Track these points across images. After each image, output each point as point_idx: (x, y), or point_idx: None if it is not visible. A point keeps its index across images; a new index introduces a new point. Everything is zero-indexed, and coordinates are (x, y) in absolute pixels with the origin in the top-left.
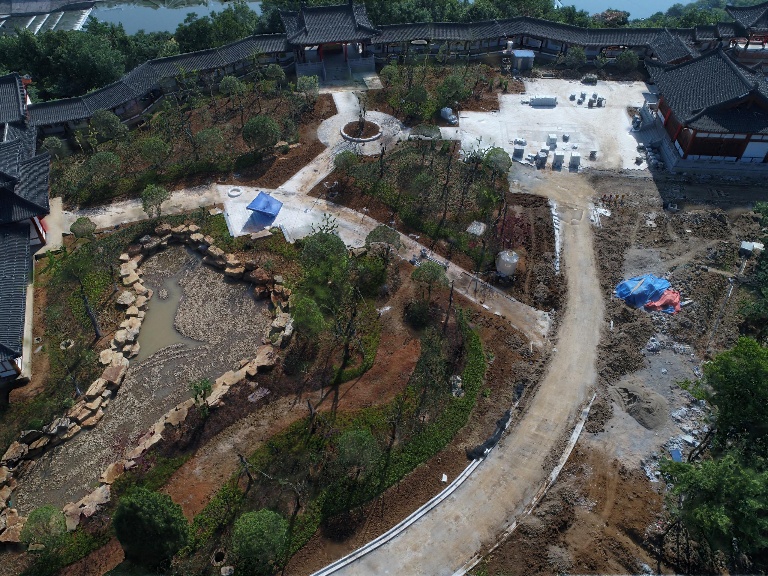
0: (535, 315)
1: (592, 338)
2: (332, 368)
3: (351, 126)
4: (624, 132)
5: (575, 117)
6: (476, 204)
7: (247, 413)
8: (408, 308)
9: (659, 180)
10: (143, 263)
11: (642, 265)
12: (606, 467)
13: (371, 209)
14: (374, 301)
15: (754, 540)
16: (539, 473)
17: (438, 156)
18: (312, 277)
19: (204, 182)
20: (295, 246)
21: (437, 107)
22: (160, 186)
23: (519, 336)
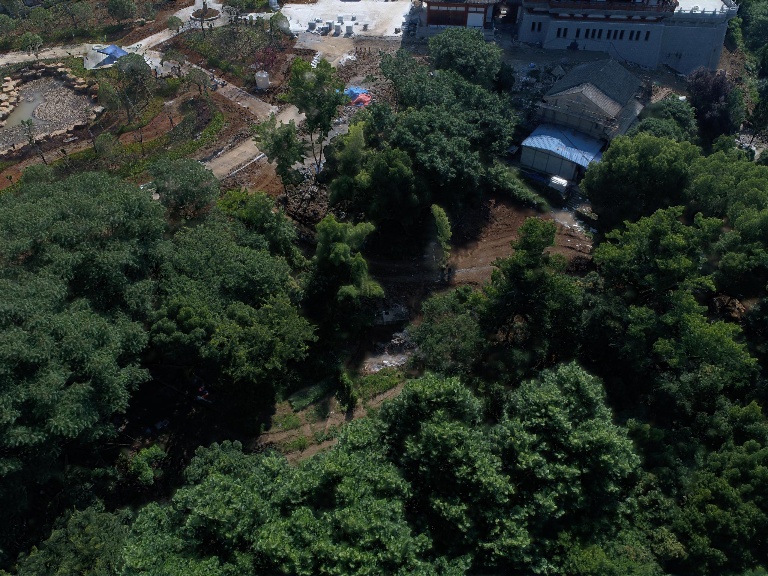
0: (270, 107)
1: (300, 118)
2: (119, 125)
3: (199, 11)
4: (400, 15)
5: (370, 7)
6: (262, 52)
7: (60, 146)
8: (185, 102)
9: (405, 42)
10: (22, 85)
11: (357, 84)
12: (271, 172)
13: (189, 56)
14: (164, 98)
15: (290, 161)
16: (227, 172)
17: (251, 27)
18: (129, 88)
19: (78, 42)
20: (125, 73)
21: (268, 0)
22: (45, 44)
23: (252, 116)
